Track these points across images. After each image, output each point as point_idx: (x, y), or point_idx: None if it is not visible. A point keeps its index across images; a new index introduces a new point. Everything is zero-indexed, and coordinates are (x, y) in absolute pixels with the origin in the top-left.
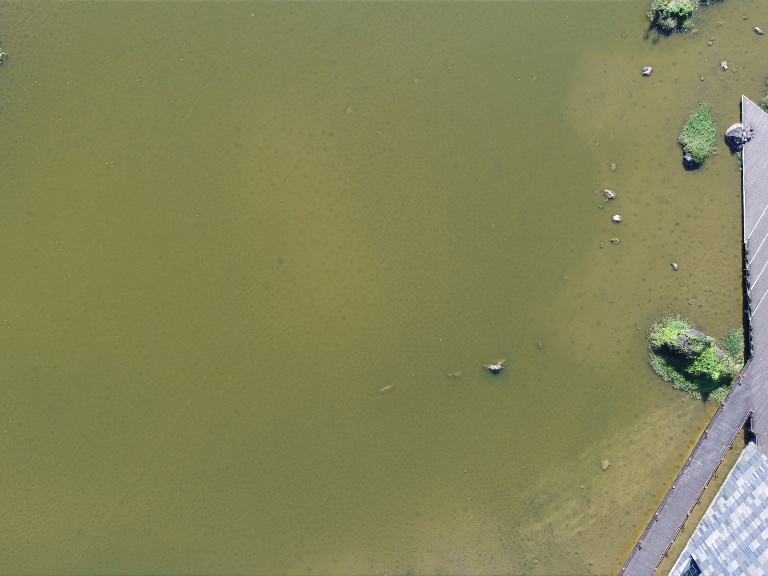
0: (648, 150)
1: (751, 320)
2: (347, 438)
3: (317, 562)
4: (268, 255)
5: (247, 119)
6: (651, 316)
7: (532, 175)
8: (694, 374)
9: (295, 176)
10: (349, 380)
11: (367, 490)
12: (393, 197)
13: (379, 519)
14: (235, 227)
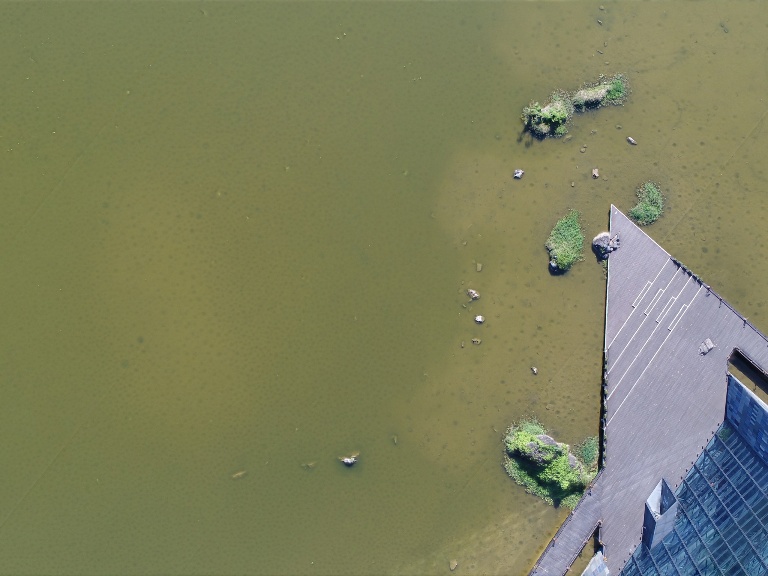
0: (515, 252)
1: (605, 430)
2: (197, 522)
3: None
4: (128, 333)
5: (116, 196)
6: (508, 418)
7: (398, 270)
8: (545, 481)
9: (161, 256)
10: (202, 464)
11: (213, 575)
12: (257, 283)
13: None
14: (97, 303)
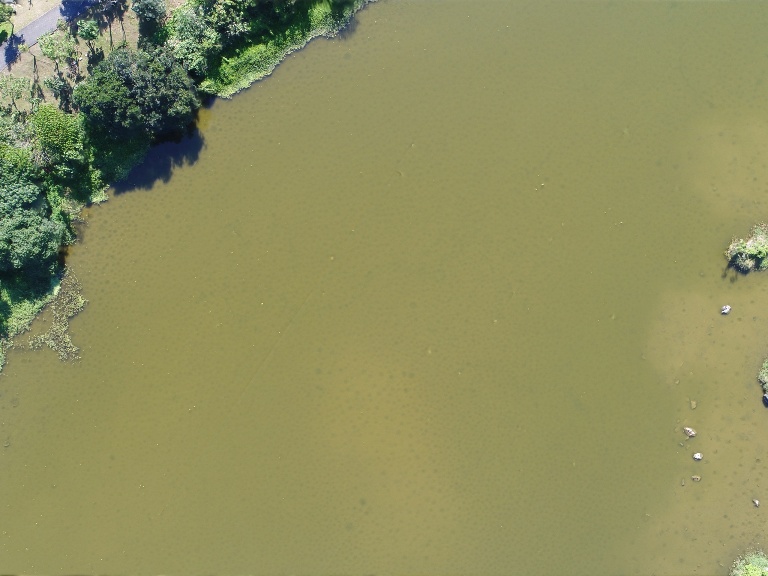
0: (728, 387)
1: None
2: None
3: None
4: (350, 496)
5: (328, 362)
6: (733, 552)
7: (612, 413)
8: None
9: (376, 417)
10: None
11: None
12: (474, 437)
13: None
14: (317, 469)
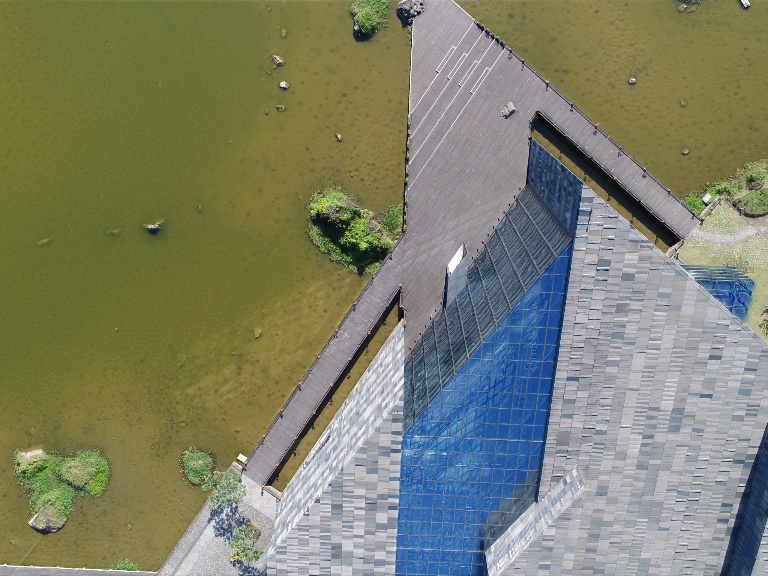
0: (320, 18)
1: (406, 194)
2: (2, 289)
3: None
4: None
5: None
6: (313, 186)
7: (202, 36)
8: (346, 245)
9: None
10: (7, 231)
11: (19, 342)
12: (62, 49)
13: (29, 372)
14: None
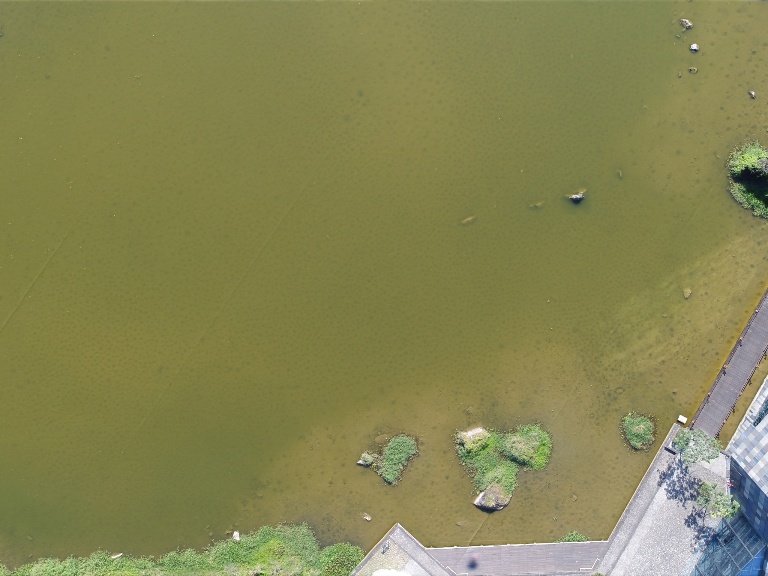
0: None
1: None
2: (429, 270)
3: (401, 396)
4: (348, 88)
5: None
6: (730, 144)
7: (610, 6)
8: None
9: (374, 9)
10: (431, 212)
11: (450, 322)
12: (472, 29)
13: (463, 351)
14: (315, 60)
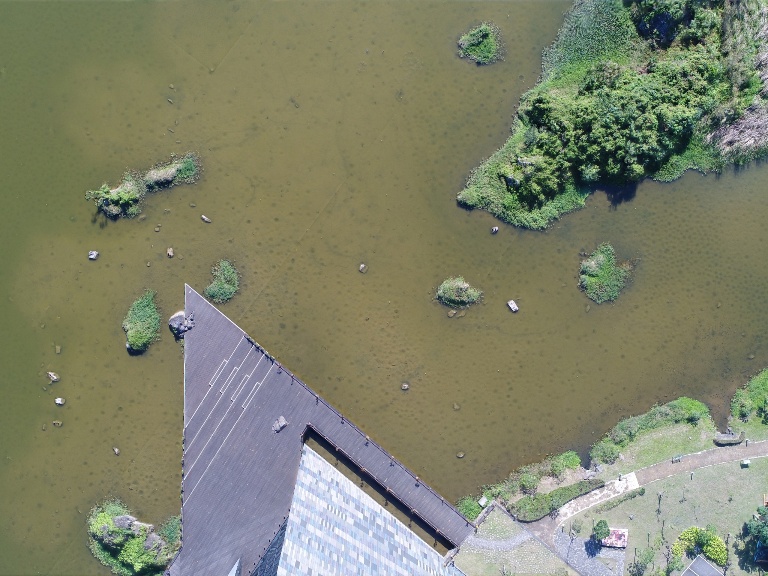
0: (93, 334)
1: (181, 510)
2: None
3: None
4: None
5: None
6: (92, 500)
7: None
8: (124, 562)
9: None
10: None
11: None
12: None
13: None
14: None
